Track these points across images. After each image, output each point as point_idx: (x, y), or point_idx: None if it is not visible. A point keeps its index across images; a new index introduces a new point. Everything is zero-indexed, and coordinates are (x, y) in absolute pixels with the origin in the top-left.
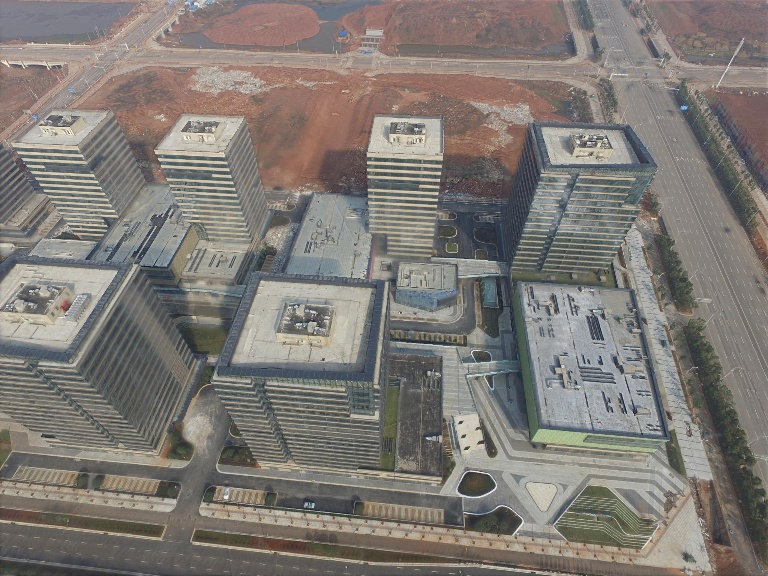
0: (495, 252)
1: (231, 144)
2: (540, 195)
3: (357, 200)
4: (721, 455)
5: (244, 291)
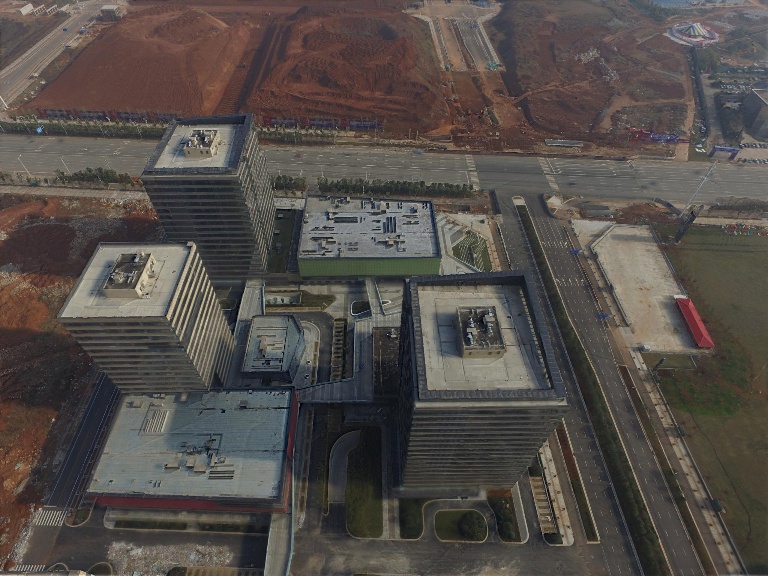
0: (223, 293)
1: (38, 574)
2: (246, 195)
3: (124, 421)
4: (417, 197)
5: (448, 408)
